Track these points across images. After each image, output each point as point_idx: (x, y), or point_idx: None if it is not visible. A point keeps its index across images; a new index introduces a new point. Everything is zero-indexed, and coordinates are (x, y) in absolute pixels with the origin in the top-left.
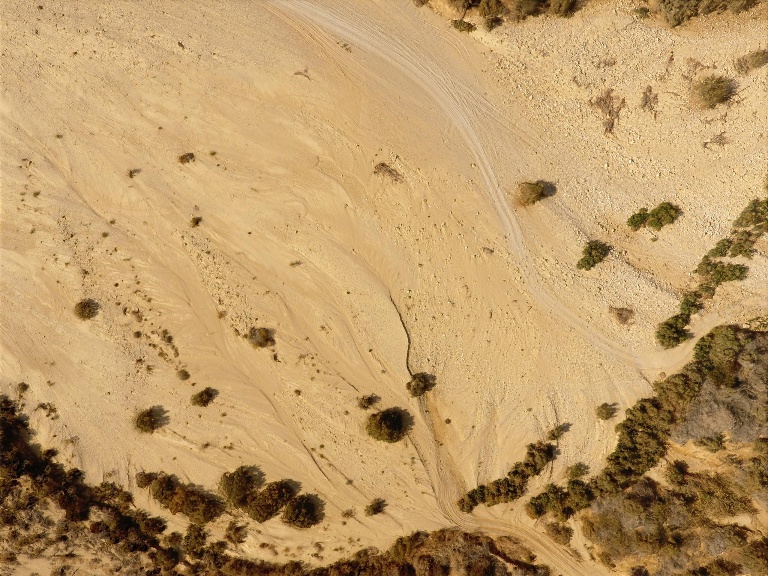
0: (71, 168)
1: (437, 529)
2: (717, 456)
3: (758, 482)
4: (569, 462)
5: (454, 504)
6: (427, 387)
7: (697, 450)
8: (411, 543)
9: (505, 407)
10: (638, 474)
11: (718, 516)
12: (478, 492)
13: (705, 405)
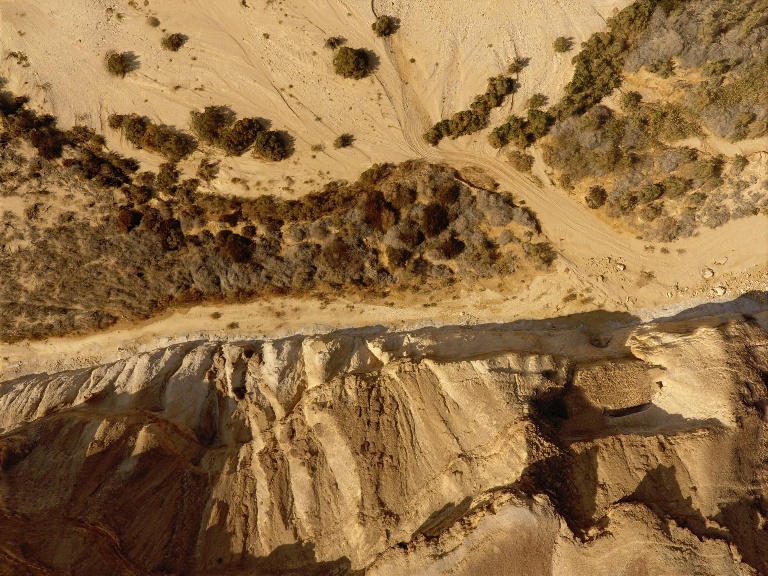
0: None
1: (404, 160)
2: (668, 82)
3: (705, 96)
4: (529, 95)
5: (420, 137)
6: (392, 30)
7: (649, 77)
8: (379, 172)
9: (467, 45)
10: (594, 101)
11: (670, 139)
12: (442, 123)
13: (655, 31)
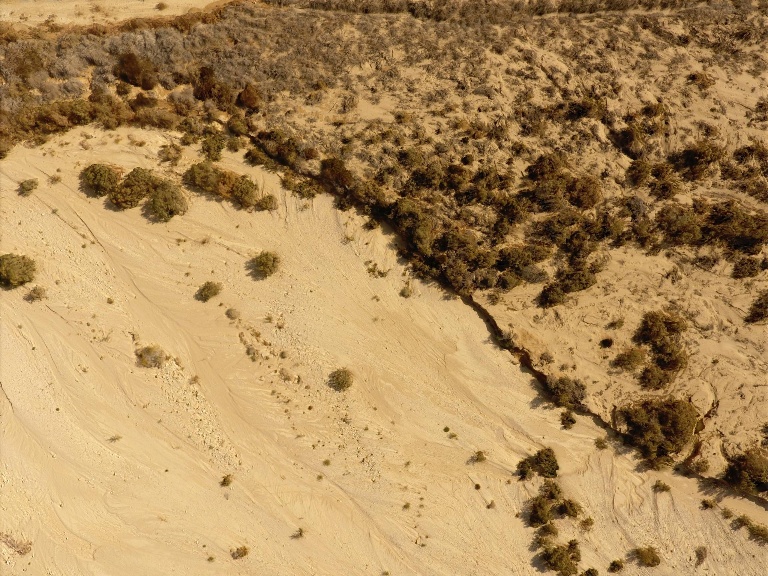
0: (370, 537)
1: None
2: None
3: None
4: None
5: None
6: None
7: None
8: None
9: None
10: None
11: None
12: None
13: None
